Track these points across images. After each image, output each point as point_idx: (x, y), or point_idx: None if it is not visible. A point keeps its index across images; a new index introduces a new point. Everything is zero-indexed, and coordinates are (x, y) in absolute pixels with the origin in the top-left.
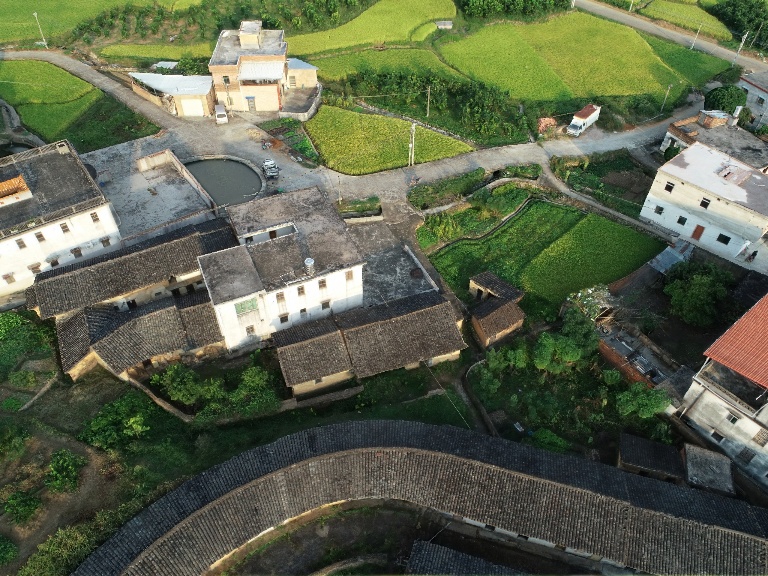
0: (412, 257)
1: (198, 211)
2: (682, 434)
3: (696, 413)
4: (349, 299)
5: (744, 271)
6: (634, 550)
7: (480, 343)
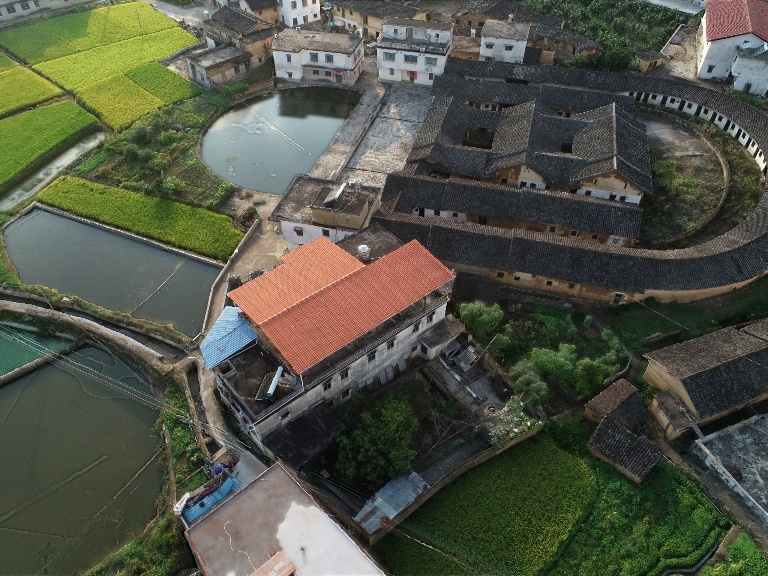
0: None
1: None
2: None
3: None
4: None
5: None
6: None
7: None
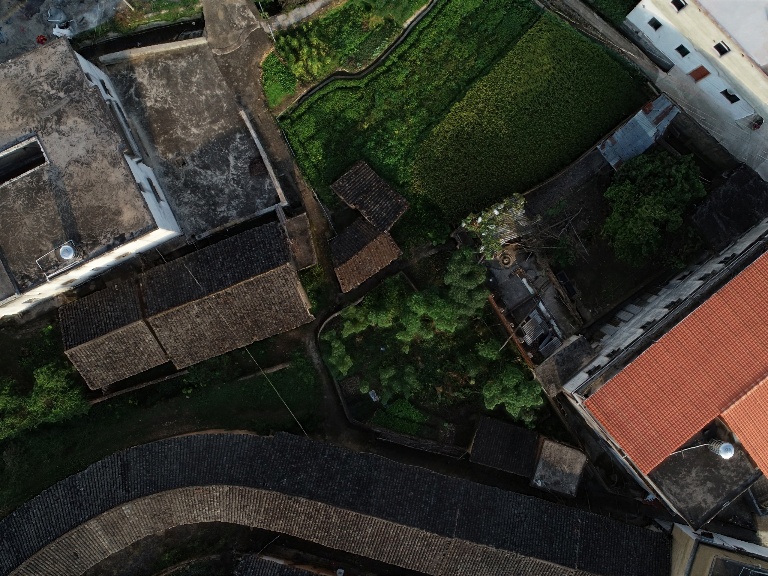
0: (251, 135)
1: None
2: (553, 408)
3: (572, 400)
4: (157, 240)
5: (732, 160)
6: (450, 566)
7: None
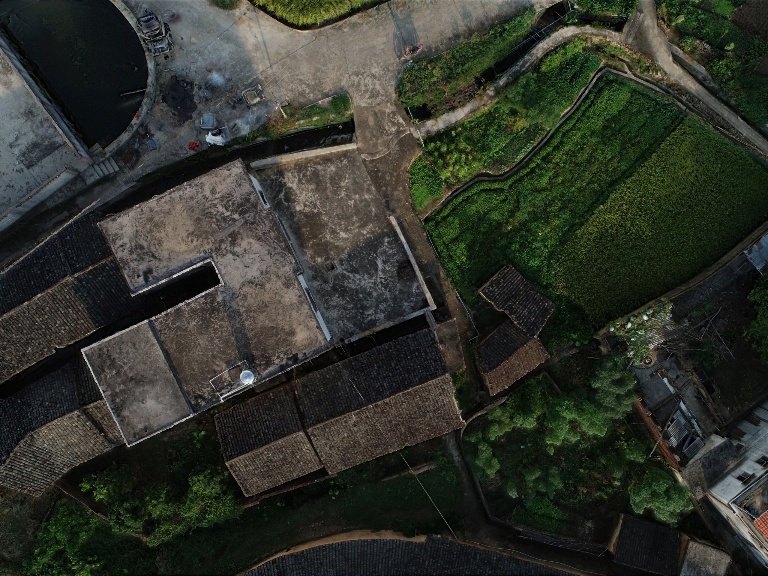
0: (401, 240)
1: (55, 176)
2: None
3: (717, 502)
4: None
5: None
6: None
7: (483, 378)
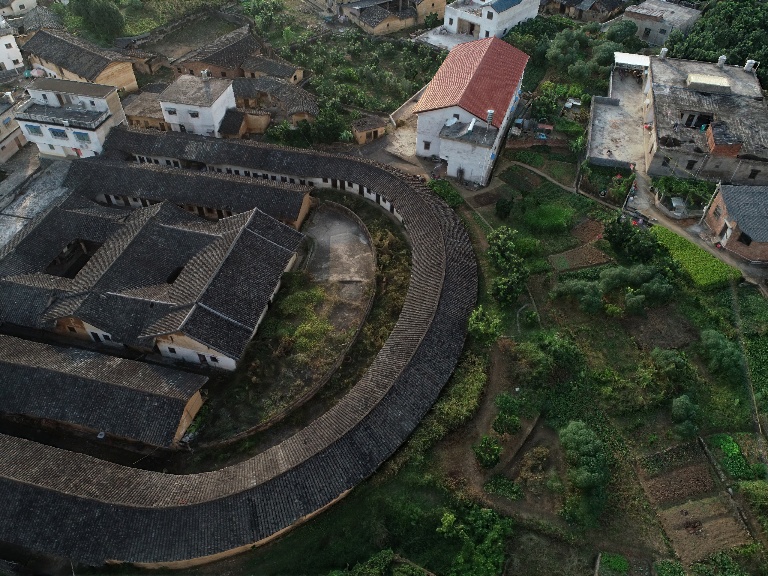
0: None
1: None
2: None
3: None
4: None
5: None
6: None
7: None
